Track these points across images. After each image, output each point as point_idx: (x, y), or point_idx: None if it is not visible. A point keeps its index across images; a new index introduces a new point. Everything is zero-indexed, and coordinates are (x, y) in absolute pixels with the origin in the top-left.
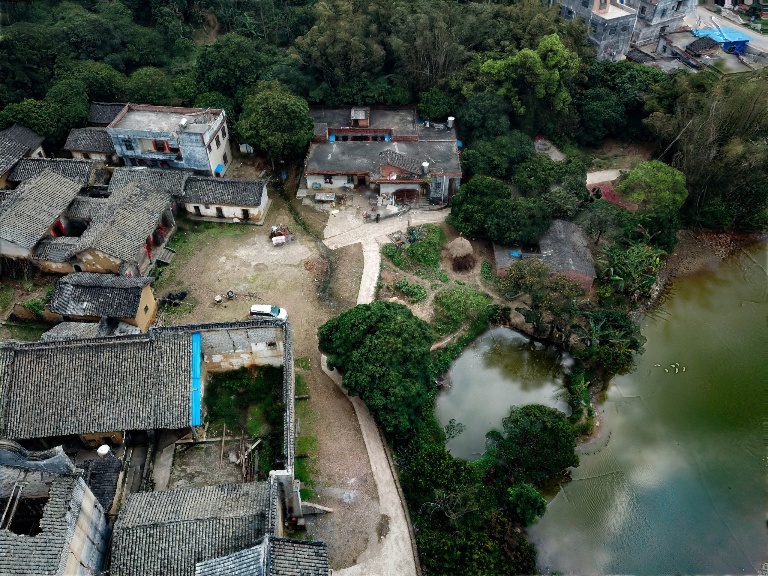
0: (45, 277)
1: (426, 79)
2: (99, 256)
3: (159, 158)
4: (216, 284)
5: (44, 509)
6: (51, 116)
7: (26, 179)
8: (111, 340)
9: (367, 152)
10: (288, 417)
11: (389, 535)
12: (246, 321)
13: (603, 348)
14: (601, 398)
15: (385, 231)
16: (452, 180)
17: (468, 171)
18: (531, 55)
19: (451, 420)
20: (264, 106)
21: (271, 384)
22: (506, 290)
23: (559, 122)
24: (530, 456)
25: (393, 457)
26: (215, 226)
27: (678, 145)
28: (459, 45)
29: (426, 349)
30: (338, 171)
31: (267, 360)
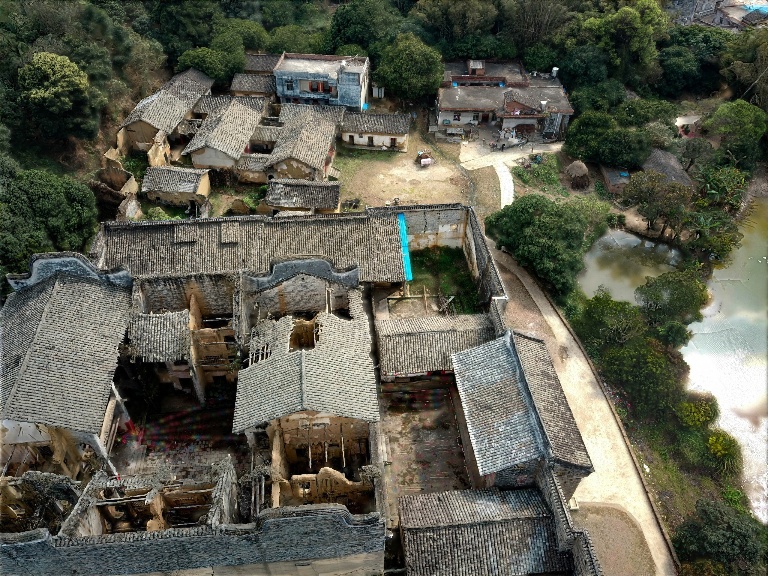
0: (241, 186)
1: (530, 37)
2: (293, 166)
3: (314, 97)
4: (382, 194)
5: (349, 306)
6: (221, 61)
7: (214, 110)
8: (338, 216)
9: (488, 94)
10: (494, 265)
11: (569, 358)
12: (441, 204)
13: (712, 238)
14: (709, 280)
15: (511, 157)
16: (563, 117)
17: (576, 110)
18: (632, 12)
19: (600, 285)
20: (408, 52)
21: (452, 259)
22: (630, 194)
23: (644, 74)
24: (675, 301)
25: (559, 310)
26: (367, 153)
27: (756, 88)
28: (563, 6)
29: (581, 228)
30: (469, 108)
31: (447, 242)
